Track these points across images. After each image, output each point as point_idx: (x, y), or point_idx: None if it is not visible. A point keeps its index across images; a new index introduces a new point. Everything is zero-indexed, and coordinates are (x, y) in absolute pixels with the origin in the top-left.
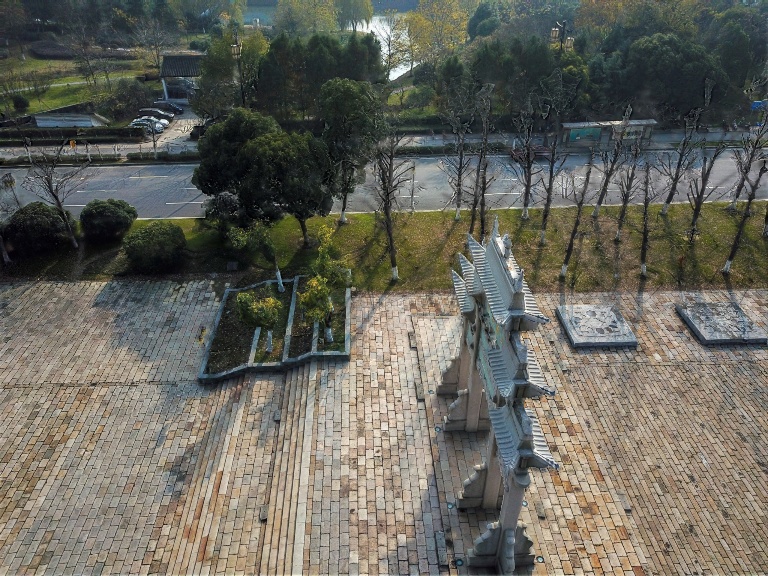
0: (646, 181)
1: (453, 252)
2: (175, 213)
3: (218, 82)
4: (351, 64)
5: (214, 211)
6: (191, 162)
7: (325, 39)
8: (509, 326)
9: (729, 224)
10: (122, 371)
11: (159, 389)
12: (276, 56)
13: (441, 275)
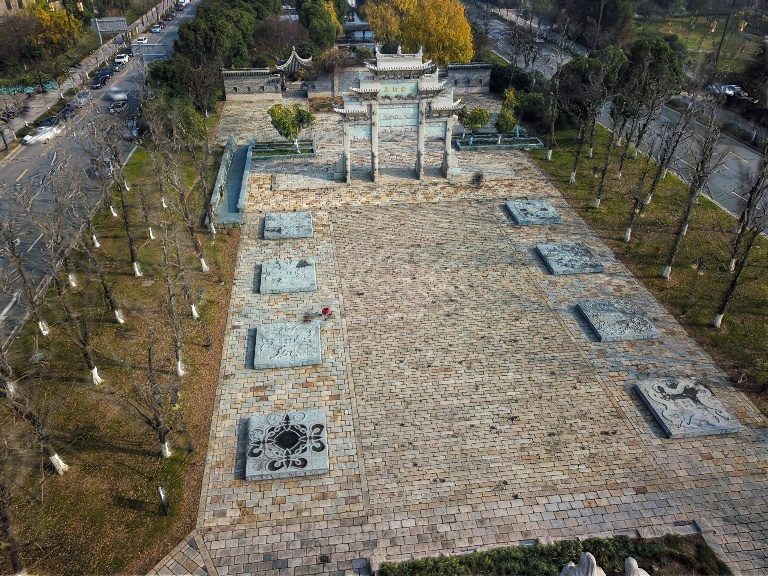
0: (650, 152)
1: None
2: None
3: None
4: None
5: None
6: (668, 105)
7: None
8: None
9: None
10: None
11: None
12: None
13: (564, 171)
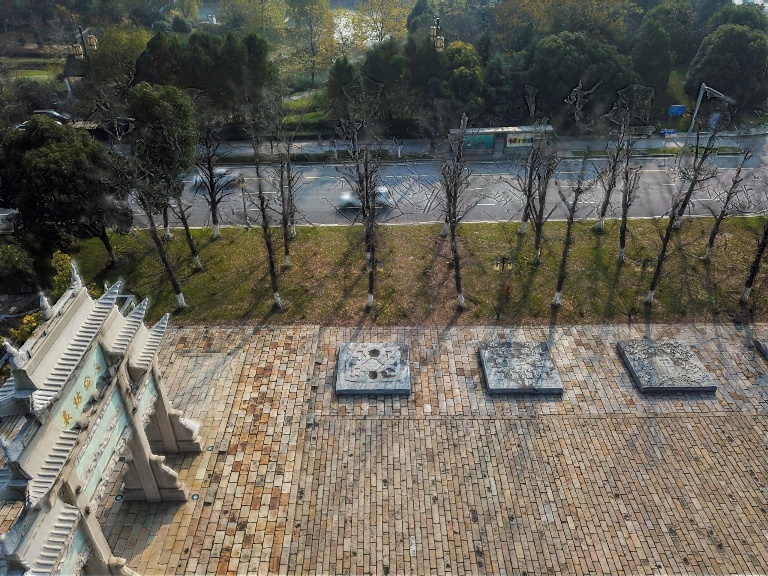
0: (448, 202)
1: (263, 276)
2: (0, 226)
3: (100, 83)
4: (228, 64)
5: (23, 226)
6: None
7: (204, 38)
8: (11, 411)
9: (588, 246)
10: None
11: None
12: (154, 56)
13: (236, 303)
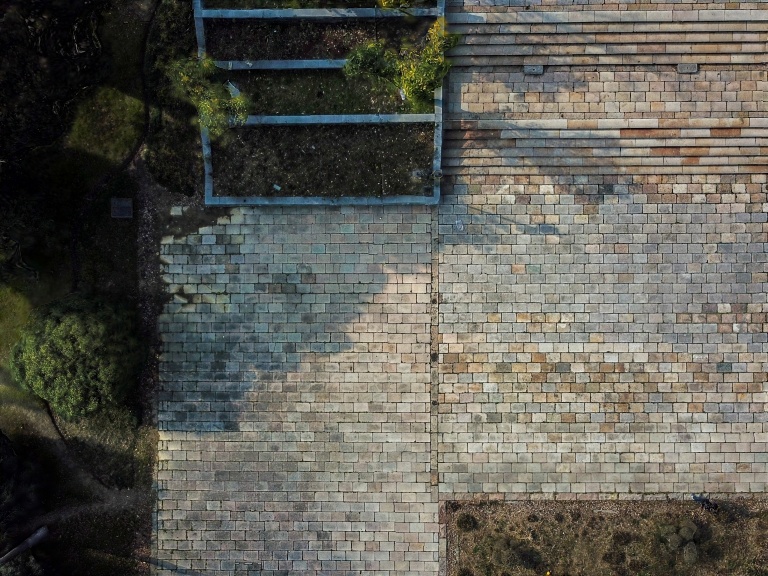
0: None
1: None
2: None
3: None
4: None
5: None
6: None
7: None
8: None
9: None
10: (407, 325)
11: (449, 259)
12: None
13: None
